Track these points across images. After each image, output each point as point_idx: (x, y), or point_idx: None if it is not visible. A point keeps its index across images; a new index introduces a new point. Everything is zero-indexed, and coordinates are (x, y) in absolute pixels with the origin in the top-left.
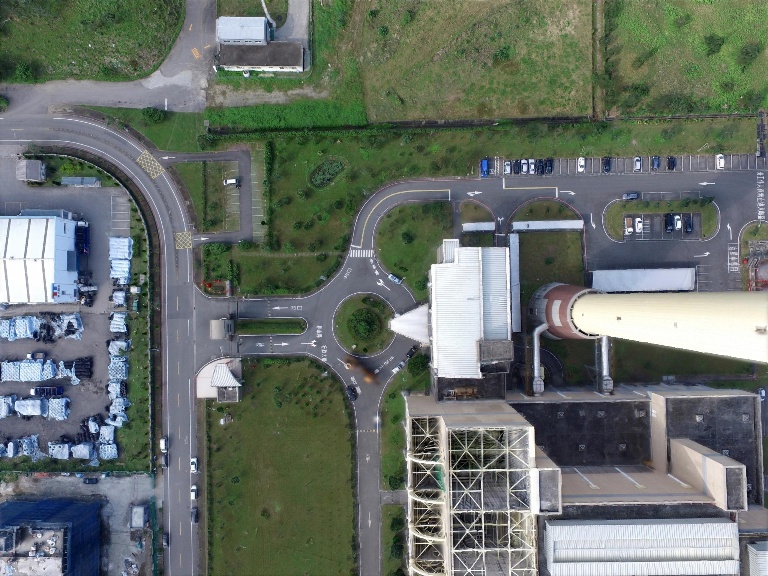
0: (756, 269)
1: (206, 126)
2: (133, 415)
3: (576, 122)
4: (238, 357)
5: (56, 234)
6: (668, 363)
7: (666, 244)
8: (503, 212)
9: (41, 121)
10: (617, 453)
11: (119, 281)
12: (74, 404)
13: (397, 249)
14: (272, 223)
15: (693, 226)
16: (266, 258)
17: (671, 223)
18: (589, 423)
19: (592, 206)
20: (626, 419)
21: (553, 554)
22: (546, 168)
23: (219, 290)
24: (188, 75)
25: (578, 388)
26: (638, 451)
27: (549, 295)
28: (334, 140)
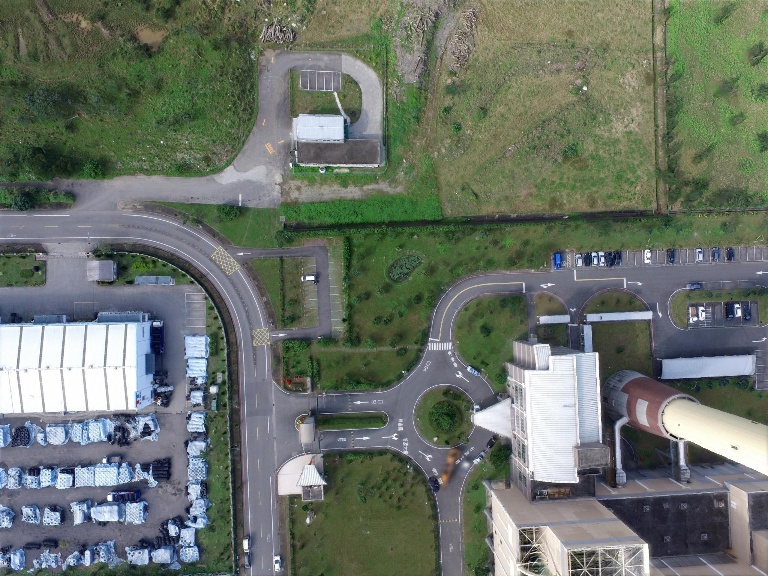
0: None
1: (282, 222)
2: (214, 515)
3: (641, 215)
4: (319, 453)
5: (137, 341)
6: None
7: (727, 331)
8: (575, 303)
9: (110, 218)
10: (699, 542)
11: (196, 380)
12: (152, 507)
13: (475, 341)
14: (351, 318)
15: (751, 313)
16: (346, 353)
17: (732, 312)
18: (672, 515)
19: (658, 296)
20: (706, 509)
21: None
22: (615, 260)
23: (299, 387)
24: (262, 170)
25: (651, 472)
26: (718, 539)
27: (629, 390)
28: (411, 235)
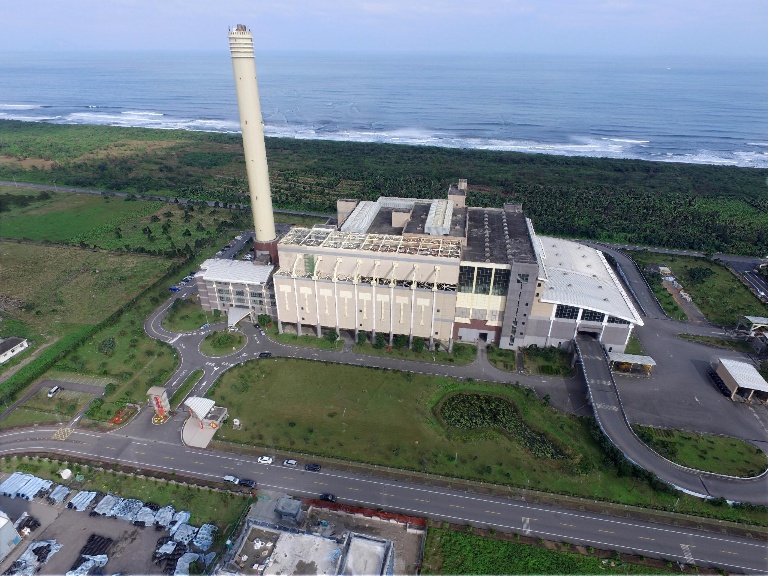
0: None
1: None
2: None
3: None
4: None
5: None
6: None
7: None
8: None
9: None
10: None
11: (43, 489)
12: (127, 569)
13: None
14: None
15: None
16: None
17: None
18: None
19: None
20: None
21: (353, 228)
22: None
23: (128, 413)
24: None
25: None
26: None
27: None
28: None
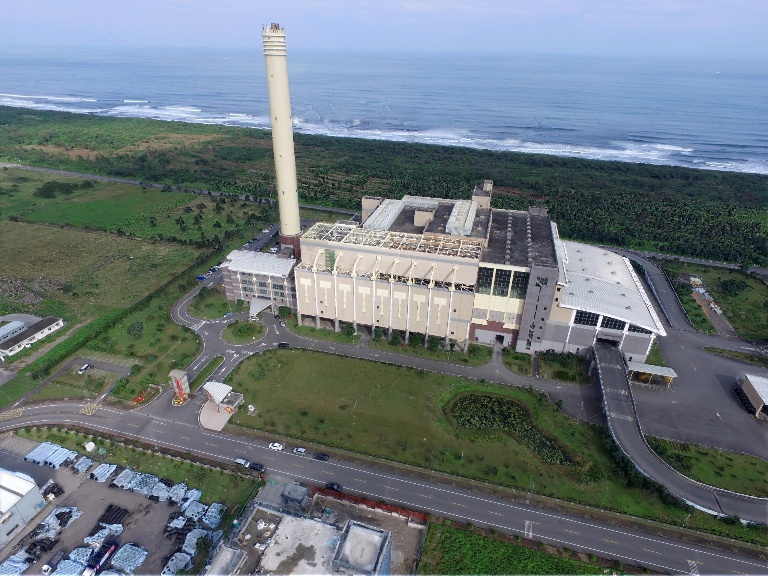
0: None
1: (29, 376)
2: None
3: None
4: None
5: None
6: None
7: None
8: None
9: None
10: None
11: (69, 459)
12: (140, 540)
13: None
14: None
15: None
16: None
17: None
18: None
19: None
20: None
21: (375, 225)
22: None
23: (150, 393)
24: None
25: None
26: None
27: None
28: None
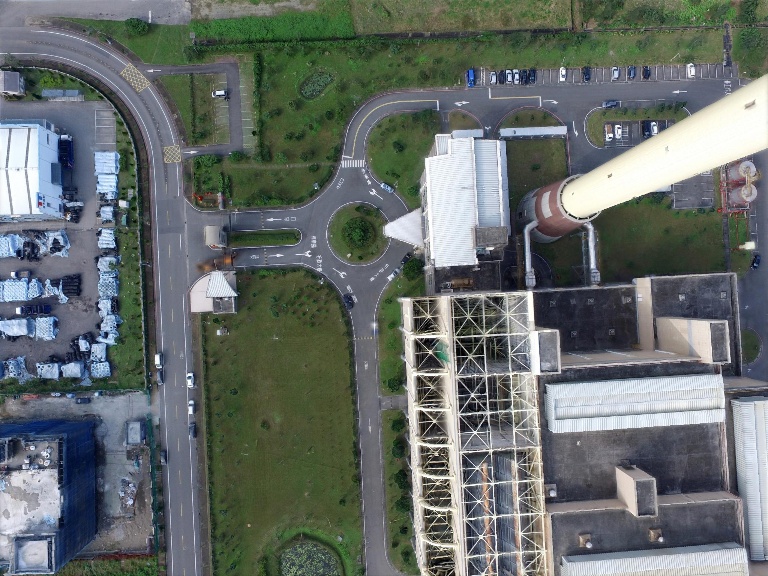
0: (727, 170)
1: (192, 38)
2: (125, 332)
3: (556, 34)
4: (232, 270)
5: (39, 143)
6: (649, 262)
7: None
8: (490, 121)
9: (18, 34)
10: (607, 338)
11: (106, 196)
12: (62, 323)
13: (388, 158)
14: (263, 135)
15: None
16: (258, 170)
17: (648, 128)
18: (580, 311)
19: (574, 114)
20: (614, 306)
21: (554, 411)
22: (530, 78)
23: (211, 203)
24: None
25: (567, 287)
26: (626, 335)
27: (538, 193)
28: (323, 51)
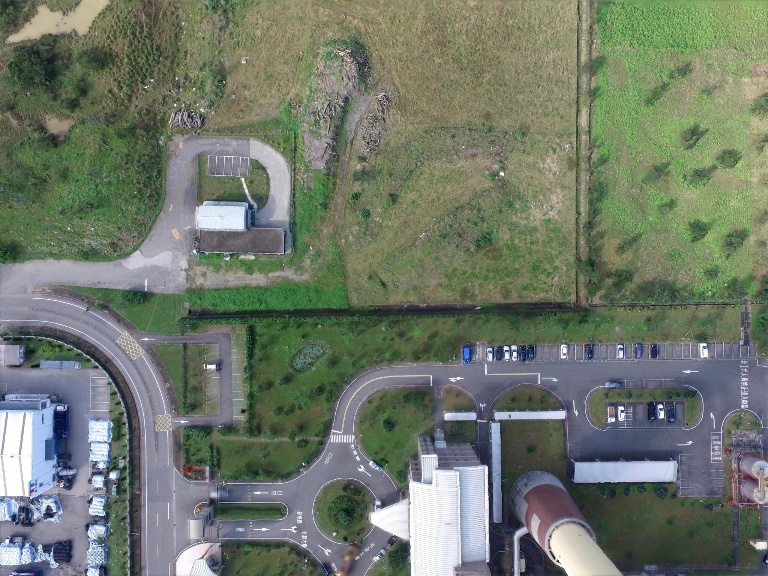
0: (739, 461)
1: (186, 308)
2: None
3: (559, 307)
4: (218, 542)
5: (33, 430)
6: (650, 553)
7: (649, 432)
8: (485, 398)
9: (20, 301)
10: None
11: (98, 465)
12: None
13: (378, 435)
14: (252, 408)
15: (676, 414)
16: (246, 443)
17: (654, 413)
18: None
19: (575, 393)
20: None
21: None
22: (528, 355)
23: (199, 475)
24: (168, 256)
25: None
26: None
27: (529, 500)
28: (315, 325)
